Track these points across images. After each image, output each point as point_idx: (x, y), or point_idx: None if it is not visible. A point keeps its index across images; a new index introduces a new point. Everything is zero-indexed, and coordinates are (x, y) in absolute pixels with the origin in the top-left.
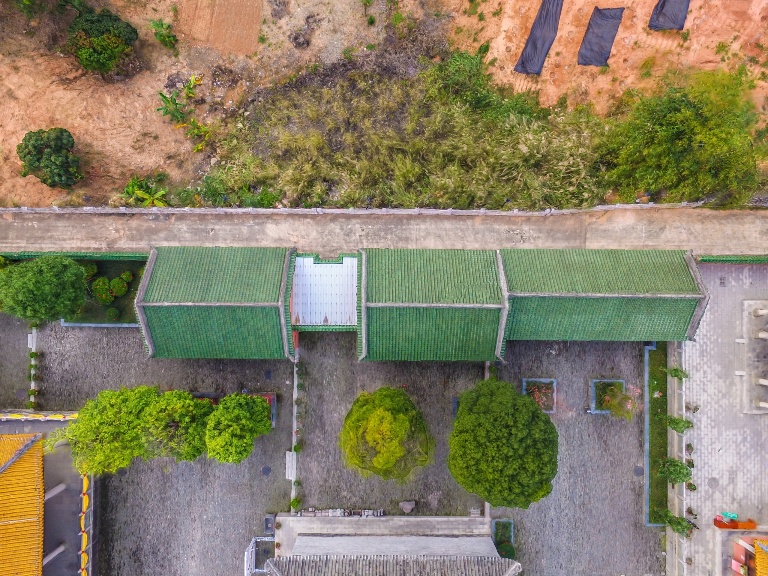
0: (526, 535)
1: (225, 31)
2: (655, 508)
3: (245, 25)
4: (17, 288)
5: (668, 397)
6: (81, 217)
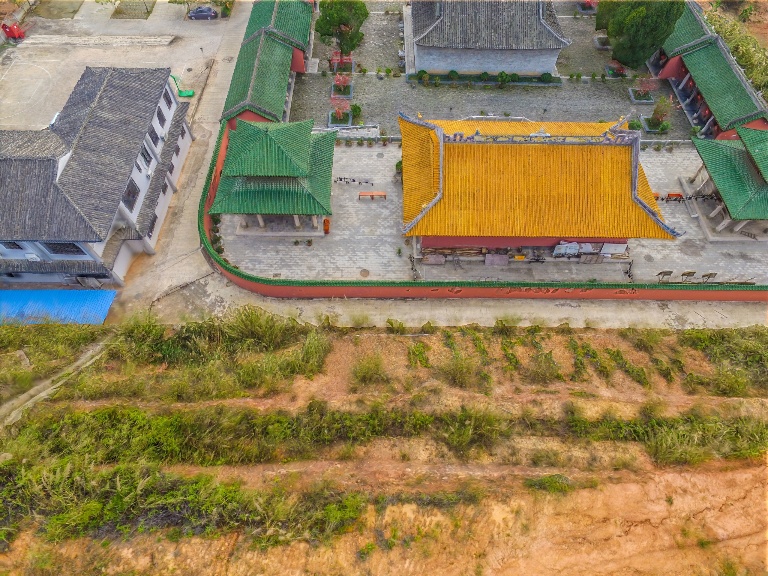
0: (554, 92)
1: (760, 38)
2: None
3: (767, 44)
4: None
5: None
6: None
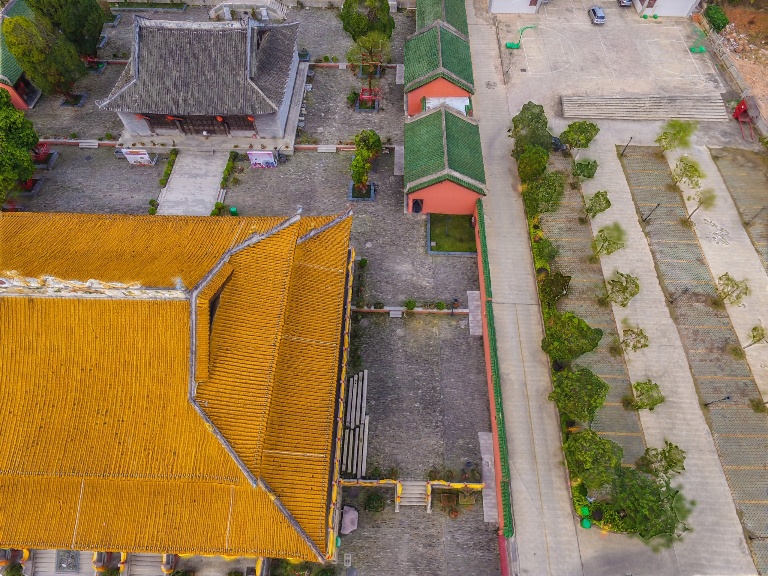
0: None
1: None
2: (170, 3)
3: None
4: None
5: (119, 2)
6: None
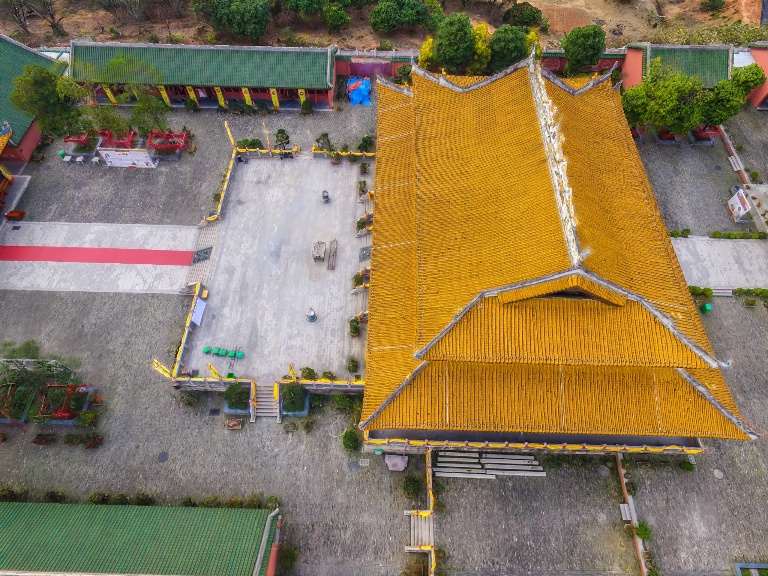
0: None
1: None
2: None
3: None
4: (593, 27)
5: None
6: (553, 58)
